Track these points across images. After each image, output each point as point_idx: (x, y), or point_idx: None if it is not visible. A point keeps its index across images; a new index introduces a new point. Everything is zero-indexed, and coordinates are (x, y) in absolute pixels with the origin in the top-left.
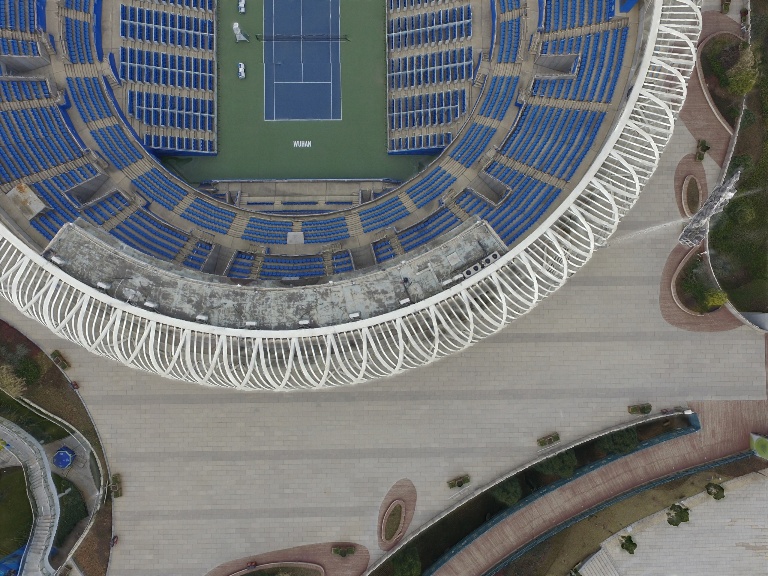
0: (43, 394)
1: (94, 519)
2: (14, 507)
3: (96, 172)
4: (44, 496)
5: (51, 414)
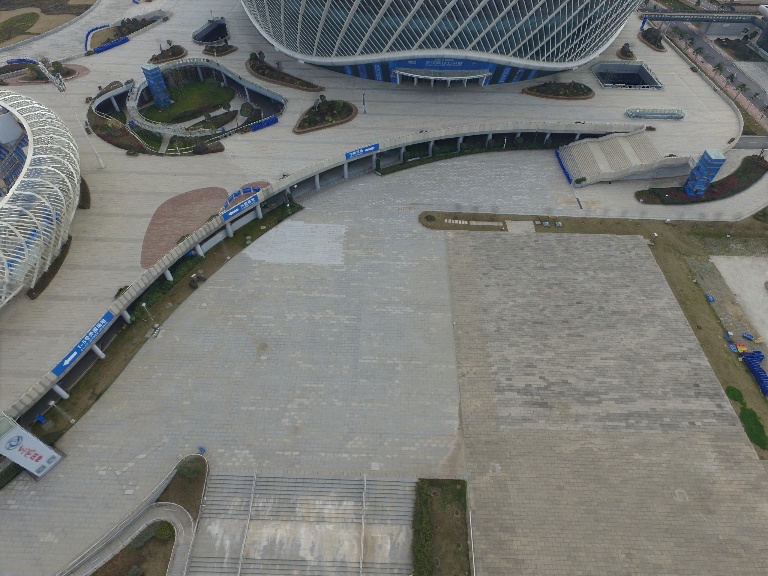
0: (105, 123)
1: (106, 93)
2: (166, 113)
3: (6, 180)
4: (132, 104)
5: (105, 118)
